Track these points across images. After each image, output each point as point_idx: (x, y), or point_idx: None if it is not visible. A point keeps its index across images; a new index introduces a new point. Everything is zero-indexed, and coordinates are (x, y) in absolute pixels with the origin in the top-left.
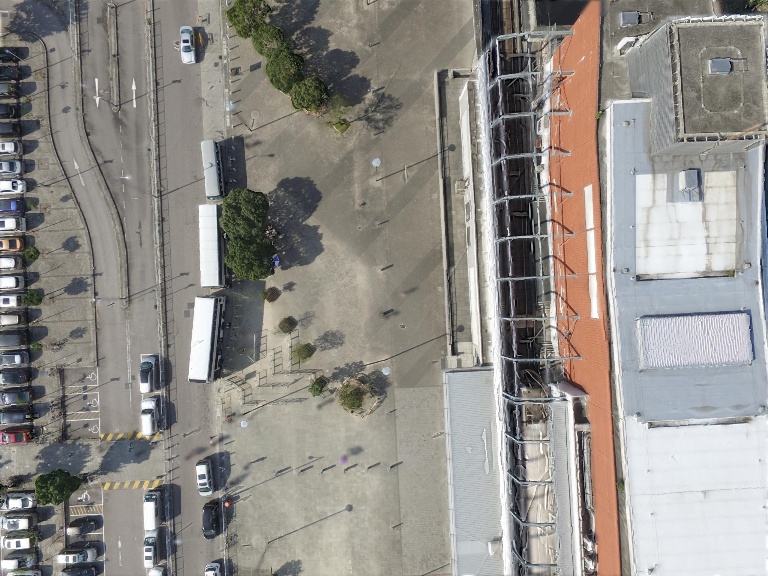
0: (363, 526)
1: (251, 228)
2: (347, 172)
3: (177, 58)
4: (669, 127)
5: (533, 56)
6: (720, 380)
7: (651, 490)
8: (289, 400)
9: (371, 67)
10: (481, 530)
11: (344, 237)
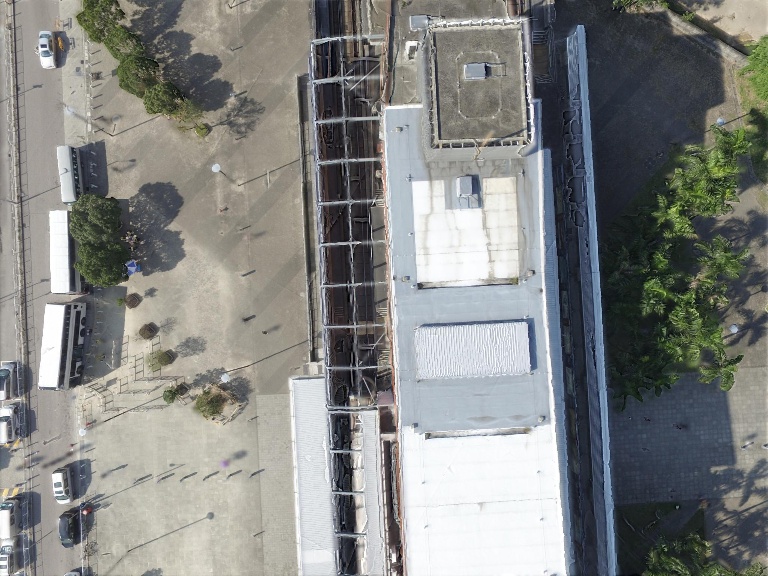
0: (224, 534)
1: (100, 234)
2: (209, 177)
3: (38, 63)
4: (430, 133)
5: (377, 60)
6: (500, 390)
7: (426, 502)
8: (150, 407)
9: (233, 71)
10: (328, 539)
11: (206, 243)
